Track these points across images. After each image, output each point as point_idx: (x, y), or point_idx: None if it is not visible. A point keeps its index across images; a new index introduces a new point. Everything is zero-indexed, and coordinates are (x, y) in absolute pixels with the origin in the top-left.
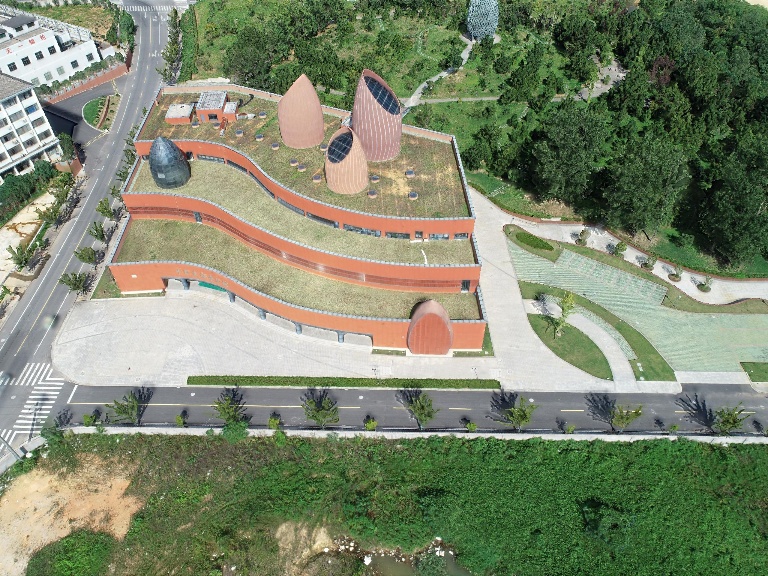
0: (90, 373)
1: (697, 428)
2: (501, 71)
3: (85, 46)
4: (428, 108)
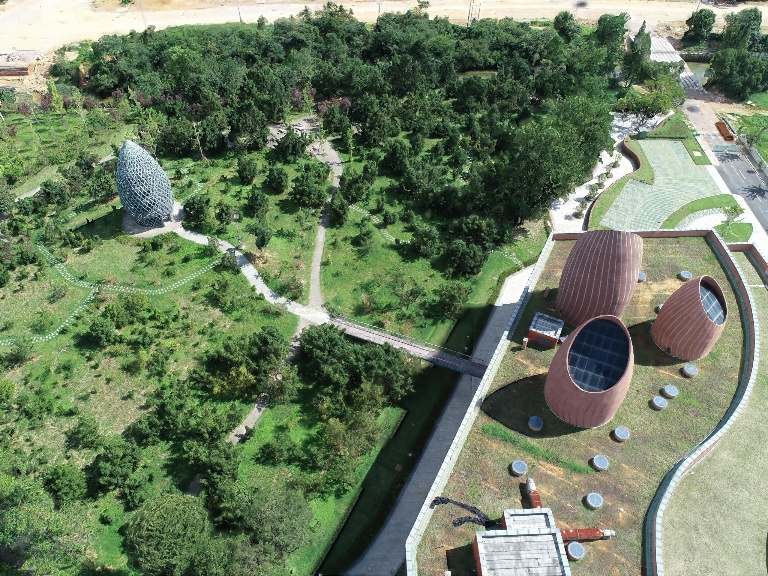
0: None
1: None
2: (268, 210)
3: None
4: (402, 276)
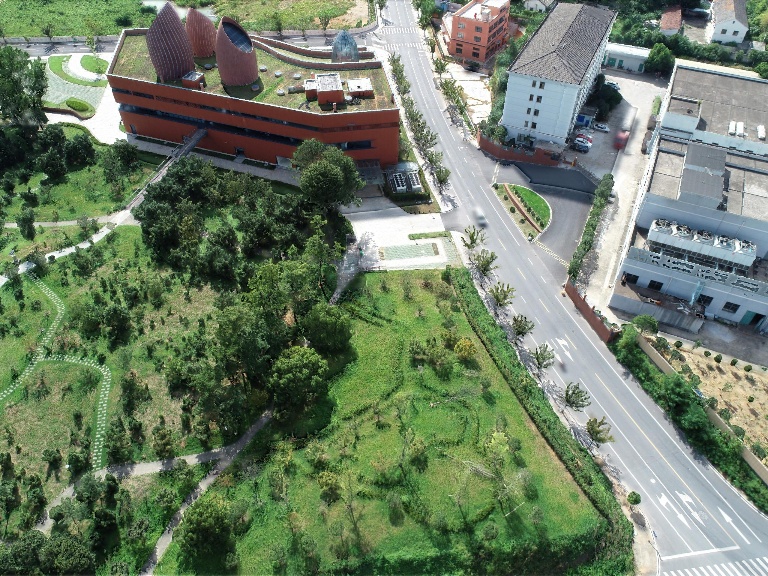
0: None
1: (58, 45)
2: None
3: None
4: None
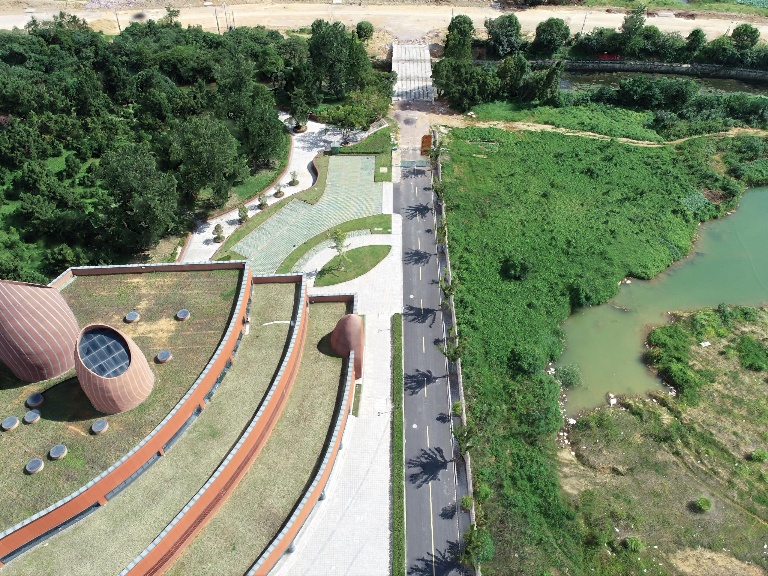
0: None
1: (431, 214)
2: None
3: None
4: None
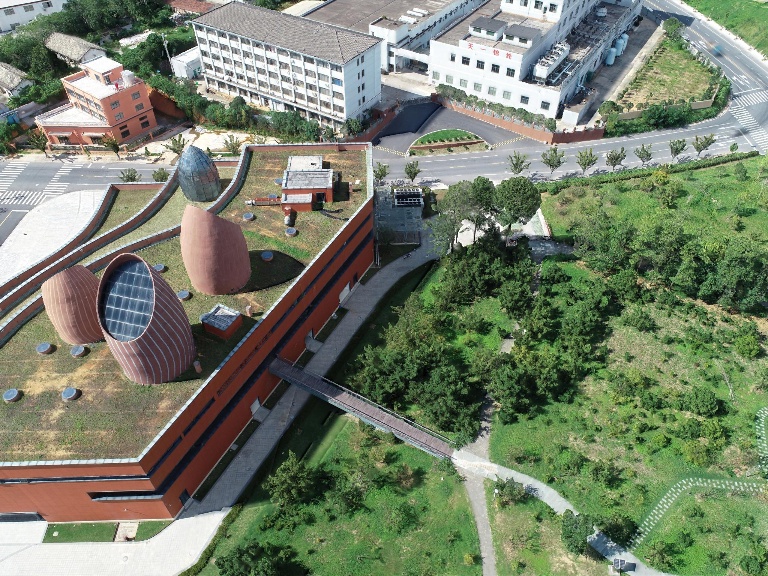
0: (36, 215)
1: None
2: None
3: (548, 92)
4: None
